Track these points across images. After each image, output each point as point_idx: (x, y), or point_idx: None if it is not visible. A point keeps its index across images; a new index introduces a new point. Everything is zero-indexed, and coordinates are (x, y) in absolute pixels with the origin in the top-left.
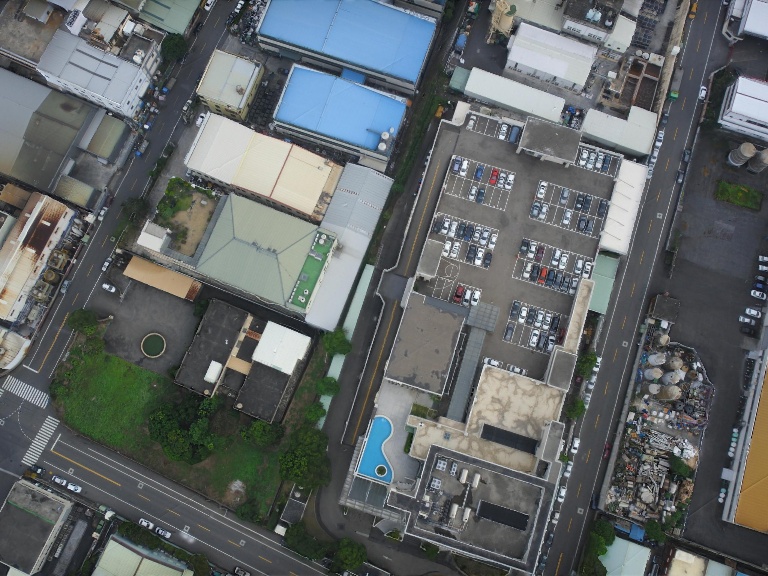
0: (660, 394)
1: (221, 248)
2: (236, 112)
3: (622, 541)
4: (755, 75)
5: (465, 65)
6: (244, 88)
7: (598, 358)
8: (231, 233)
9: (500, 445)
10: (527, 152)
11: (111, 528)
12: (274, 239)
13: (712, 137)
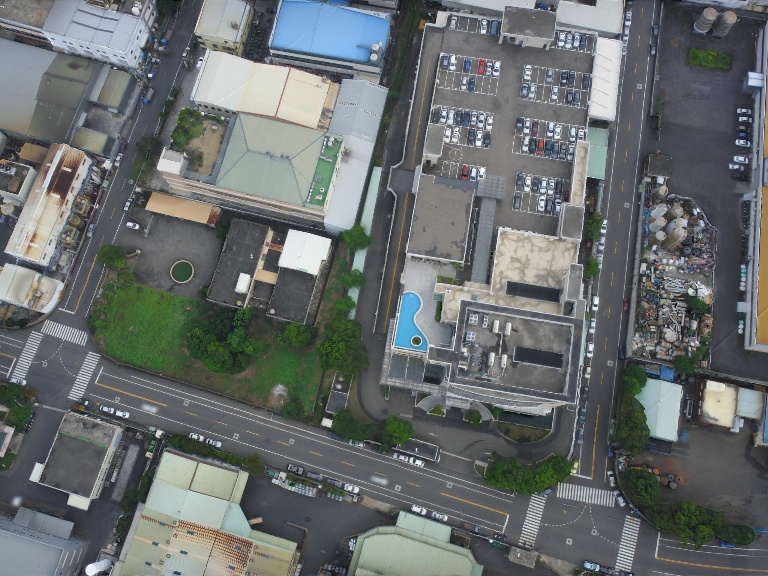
0: (667, 242)
1: (237, 161)
2: (233, 48)
3: (654, 381)
4: None
5: None
6: (238, 24)
7: (604, 220)
8: (244, 147)
9: (525, 299)
10: (509, 41)
11: (163, 445)
12: (285, 147)
13: (676, 12)
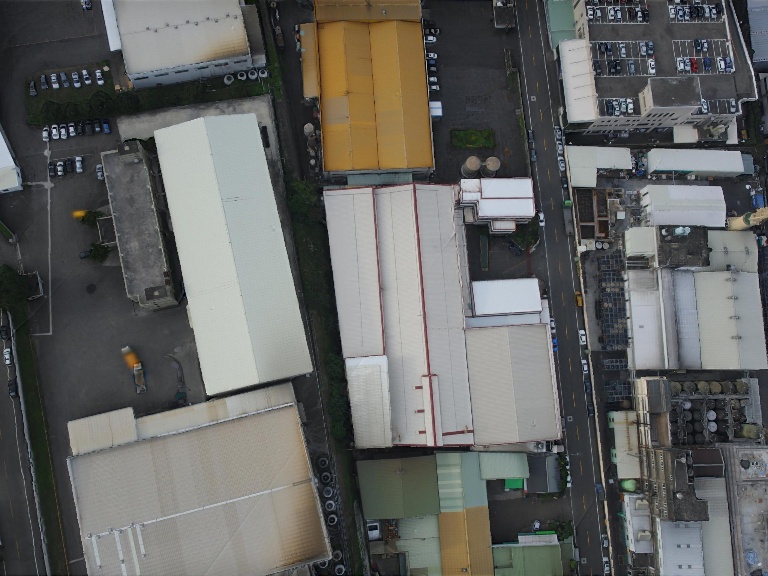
0: None
1: None
2: None
3: None
4: (499, 255)
5: (744, 185)
6: None
7: None
8: None
9: None
10: None
11: None
12: None
13: None
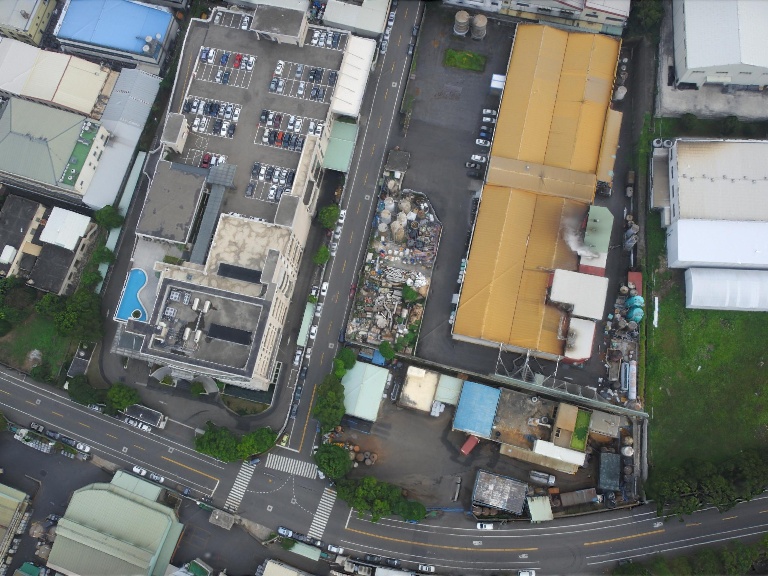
0: (392, 234)
1: (0, 141)
2: (26, 36)
3: (361, 364)
4: None
5: None
6: (29, 13)
7: (342, 211)
8: (9, 128)
9: (235, 280)
10: (265, 37)
11: None
12: (46, 130)
13: (440, 14)
